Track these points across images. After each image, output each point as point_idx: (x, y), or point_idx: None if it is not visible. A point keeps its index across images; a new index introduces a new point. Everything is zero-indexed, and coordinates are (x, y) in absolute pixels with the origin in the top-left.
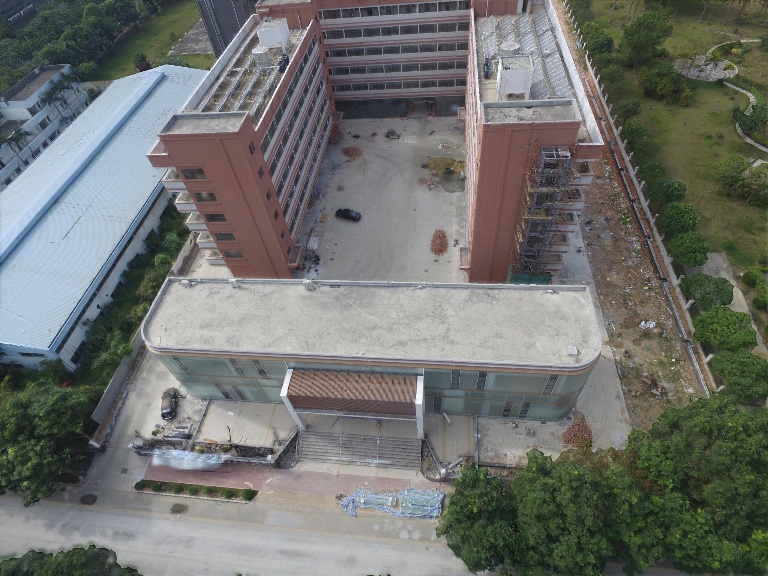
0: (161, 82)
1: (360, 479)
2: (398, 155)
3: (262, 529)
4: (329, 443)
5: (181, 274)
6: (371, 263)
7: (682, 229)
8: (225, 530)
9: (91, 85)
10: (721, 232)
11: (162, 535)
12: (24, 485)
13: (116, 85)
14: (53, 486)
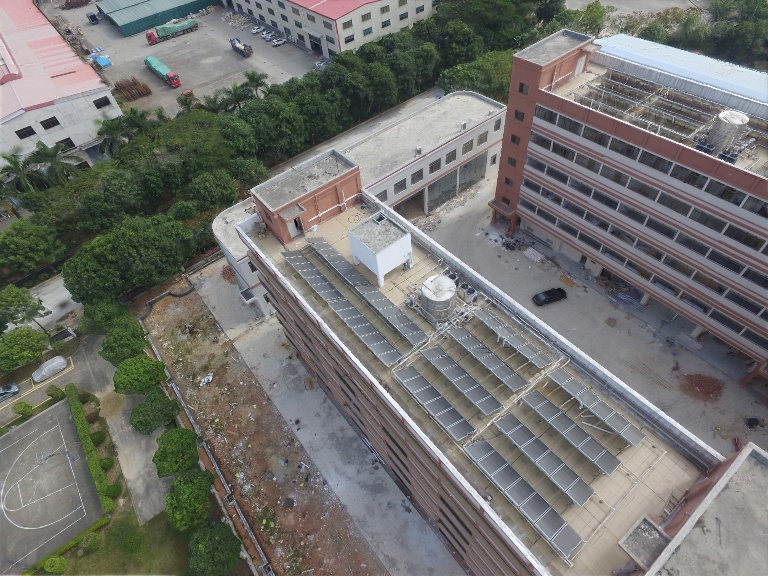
0: None
1: None
2: None
3: None
4: None
5: None
6: None
7: None
8: None
9: None
10: (144, 575)
11: None
12: (441, 75)
13: None
14: None
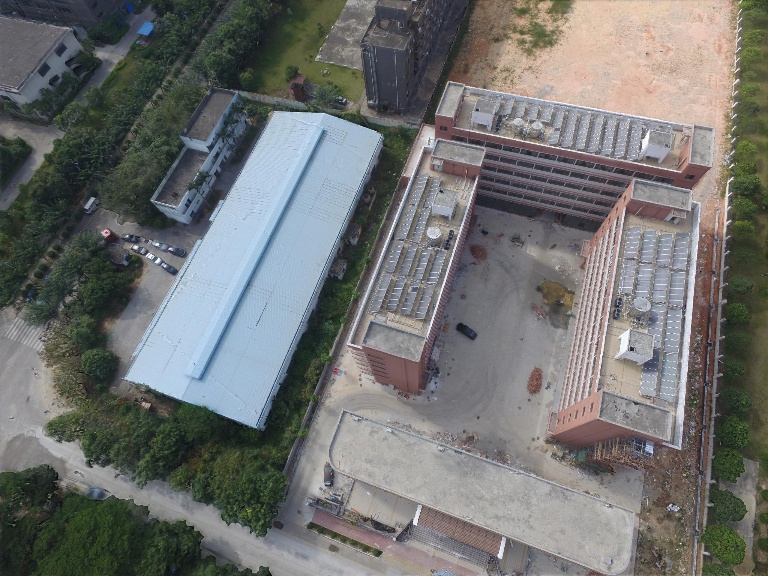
0: (321, 139)
1: (447, 563)
2: (518, 268)
3: None
4: (431, 535)
5: (334, 357)
6: (478, 388)
7: (731, 445)
8: (362, 572)
9: (248, 95)
10: (766, 440)
11: (324, 563)
12: (257, 532)
13: (277, 122)
14: None
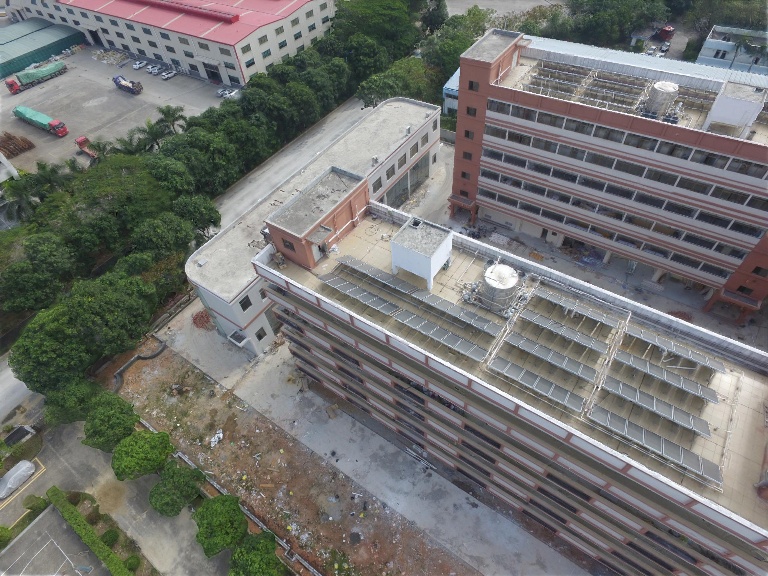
0: None
1: None
2: None
3: None
4: None
5: None
6: None
7: None
8: None
9: None
10: None
11: None
12: (359, 87)
13: None
14: (367, 106)
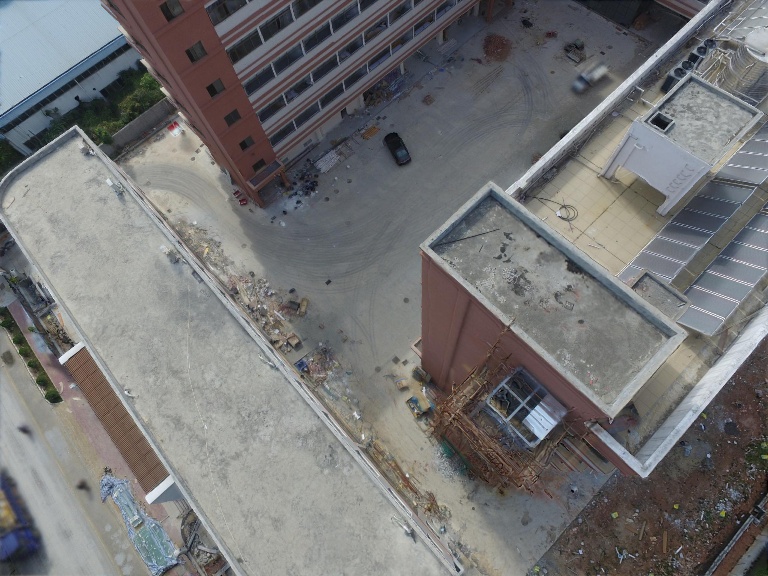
0: None
1: None
2: (549, 93)
3: (38, 437)
4: None
5: None
6: (359, 238)
7: None
8: (18, 410)
9: None
10: None
11: None
12: None
13: None
14: None
